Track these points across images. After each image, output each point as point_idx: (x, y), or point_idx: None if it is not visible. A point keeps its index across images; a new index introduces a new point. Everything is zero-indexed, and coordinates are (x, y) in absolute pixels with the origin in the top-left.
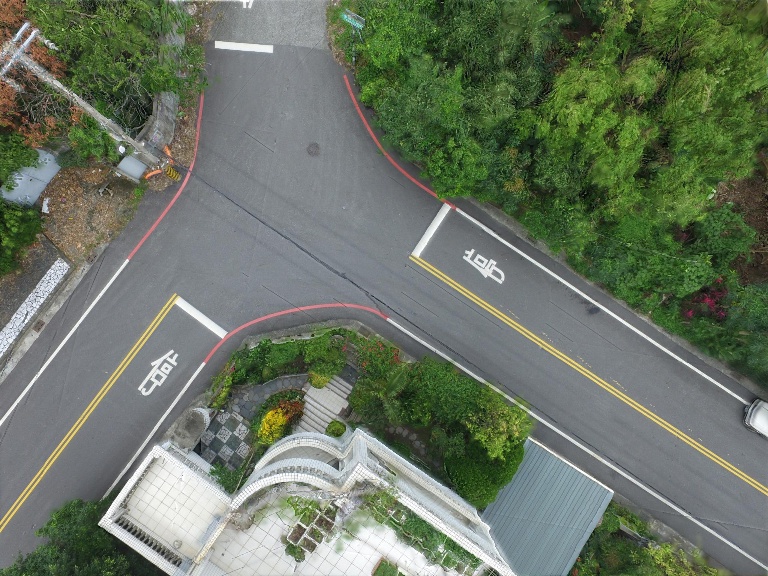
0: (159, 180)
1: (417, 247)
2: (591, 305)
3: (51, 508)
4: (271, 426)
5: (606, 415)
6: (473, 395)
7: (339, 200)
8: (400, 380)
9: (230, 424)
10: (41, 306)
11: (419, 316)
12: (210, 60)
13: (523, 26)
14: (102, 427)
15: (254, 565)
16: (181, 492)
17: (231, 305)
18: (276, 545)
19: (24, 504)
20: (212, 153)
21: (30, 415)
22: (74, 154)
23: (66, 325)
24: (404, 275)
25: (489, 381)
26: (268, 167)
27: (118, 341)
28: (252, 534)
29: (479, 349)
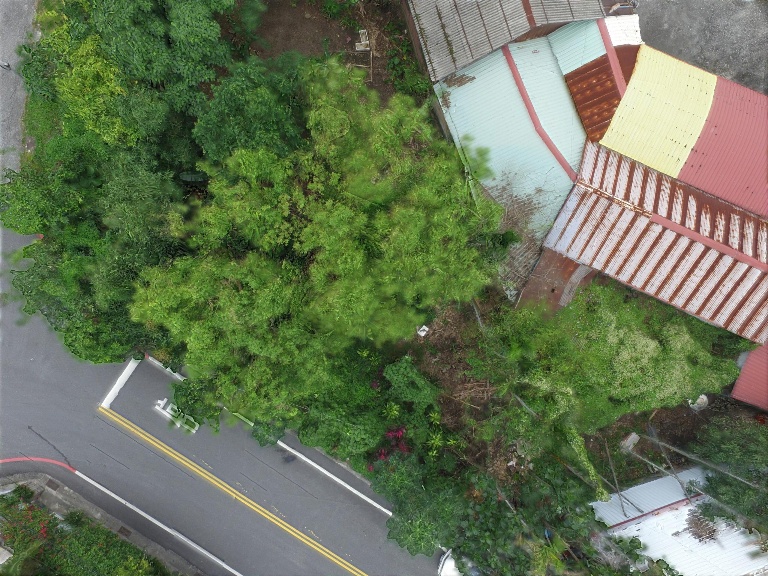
0: None
1: (107, 398)
2: (287, 453)
3: None
4: None
5: (300, 566)
6: (116, 571)
7: (27, 351)
8: (15, 570)
9: None
10: None
11: (109, 468)
12: None
13: (200, 180)
14: None
15: None
16: None
17: None
18: None
19: None
20: None
21: None
22: None
23: None
24: (93, 427)
25: (182, 532)
26: None
27: None
28: None
29: (171, 500)
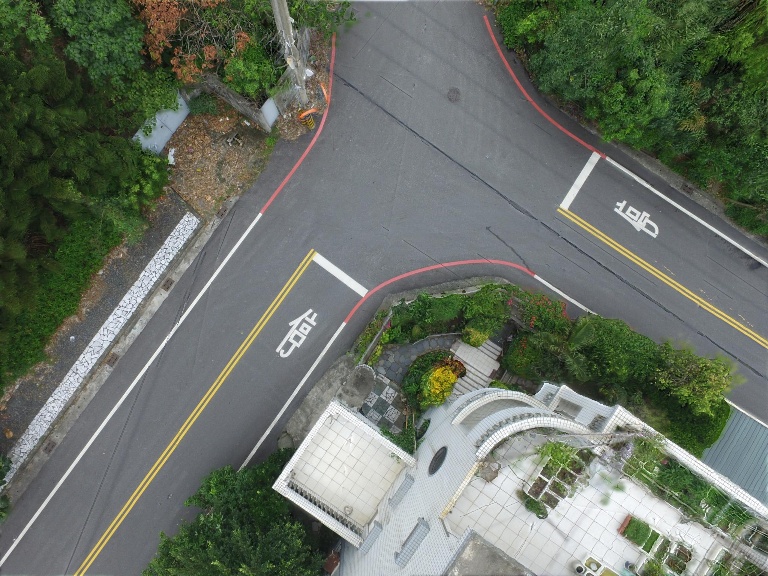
0: (291, 128)
1: (566, 199)
2: (751, 260)
3: (187, 477)
4: (442, 384)
5: None
6: (652, 351)
7: (482, 149)
8: (586, 332)
9: (376, 387)
10: (170, 263)
11: (568, 273)
12: (341, 0)
13: None
14: (239, 391)
15: (485, 523)
16: (350, 454)
17: (371, 261)
18: (509, 501)
19: (159, 473)
20: (346, 99)
21: (162, 379)
22: (205, 99)
23: (197, 283)
24: None
25: None
26: (407, 114)
27: (253, 300)
28: (483, 489)
29: (632, 308)
